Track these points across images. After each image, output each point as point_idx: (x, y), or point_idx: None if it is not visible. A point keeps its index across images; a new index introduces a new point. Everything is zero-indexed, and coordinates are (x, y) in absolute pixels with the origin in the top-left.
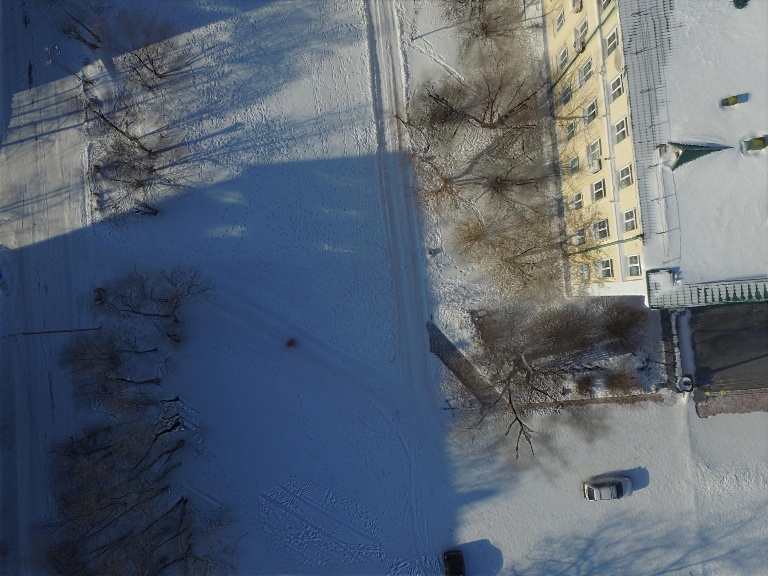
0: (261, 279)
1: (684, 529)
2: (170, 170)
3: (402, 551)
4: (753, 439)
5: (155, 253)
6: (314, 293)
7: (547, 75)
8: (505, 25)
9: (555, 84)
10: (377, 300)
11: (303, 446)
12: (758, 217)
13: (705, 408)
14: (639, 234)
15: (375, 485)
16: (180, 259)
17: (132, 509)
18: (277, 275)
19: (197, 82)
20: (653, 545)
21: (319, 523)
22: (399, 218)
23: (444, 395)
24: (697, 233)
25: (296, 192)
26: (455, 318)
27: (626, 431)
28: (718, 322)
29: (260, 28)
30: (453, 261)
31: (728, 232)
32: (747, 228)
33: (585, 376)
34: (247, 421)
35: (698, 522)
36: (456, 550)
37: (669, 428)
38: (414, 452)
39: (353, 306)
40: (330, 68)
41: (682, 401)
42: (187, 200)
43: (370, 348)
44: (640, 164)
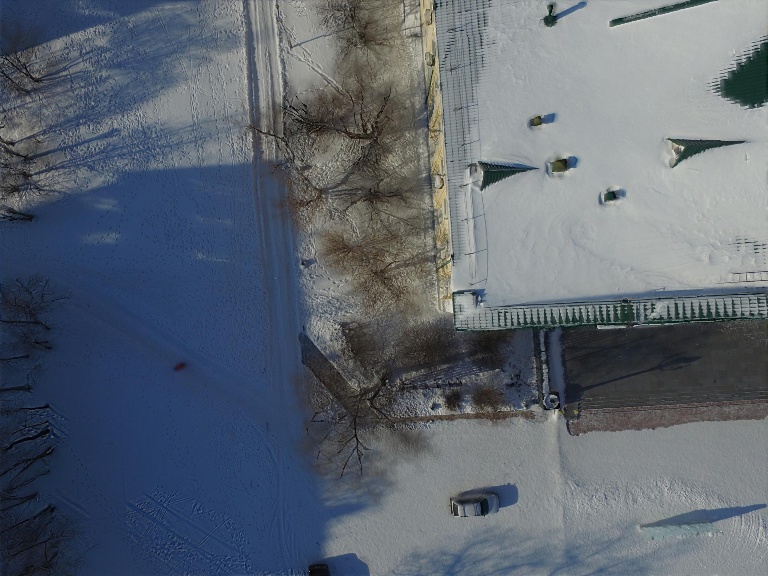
0: (134, 287)
1: (552, 547)
2: (46, 175)
3: (268, 563)
4: (624, 458)
5: (30, 259)
6: (186, 302)
7: (425, 86)
8: (384, 34)
9: (428, 95)
10: (249, 310)
11: (171, 456)
12: (561, 240)
13: (576, 425)
14: (451, 254)
15: (243, 497)
16: (55, 265)
17: None
18: (150, 283)
19: (75, 87)
20: (520, 562)
21: (185, 534)
22: (274, 228)
23: (314, 407)
24: (503, 255)
25: (171, 200)
26: (326, 330)
27: (496, 447)
28: (589, 339)
29: (139, 33)
30: (326, 272)
31: (533, 254)
32: (551, 251)
33: (455, 391)
34: (116, 430)
35: (566, 540)
36: (321, 564)
37: (539, 445)
38: (282, 464)
39: (225, 316)
40: (208, 75)
41: (553, 418)
42: (62, 206)
43: (241, 359)
44: (452, 183)
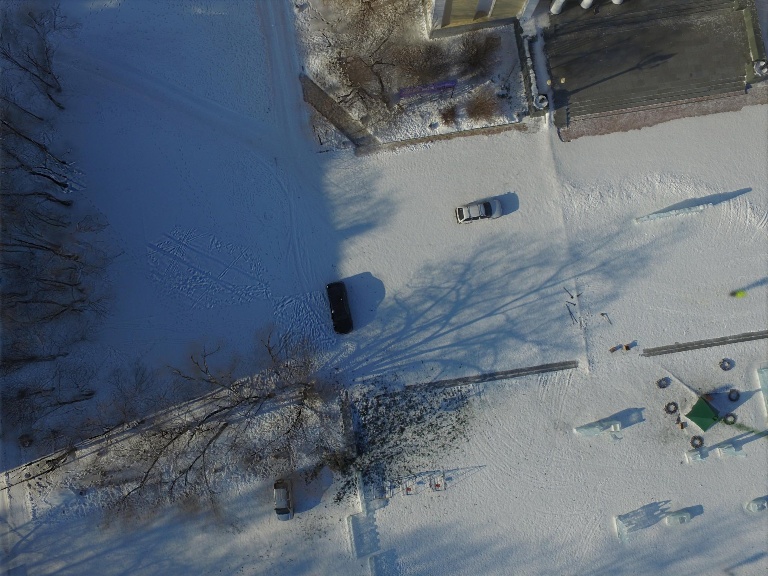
0: (139, 46)
1: (555, 247)
2: None
3: (287, 288)
4: (614, 158)
5: None
6: (190, 54)
7: None
8: None
9: None
10: (250, 56)
11: (186, 196)
12: None
13: (567, 133)
14: None
15: (258, 228)
16: None
17: (25, 269)
18: (154, 41)
19: None
20: (527, 265)
21: (206, 268)
22: None
23: None
24: None
25: None
26: (324, 66)
27: (494, 160)
28: (570, 47)
29: None
30: (320, 14)
31: None
32: None
33: (450, 109)
34: (132, 177)
35: (568, 239)
36: None
37: (534, 154)
38: (293, 194)
39: (227, 63)
40: None
41: (544, 127)
42: None
43: (246, 101)
44: None
